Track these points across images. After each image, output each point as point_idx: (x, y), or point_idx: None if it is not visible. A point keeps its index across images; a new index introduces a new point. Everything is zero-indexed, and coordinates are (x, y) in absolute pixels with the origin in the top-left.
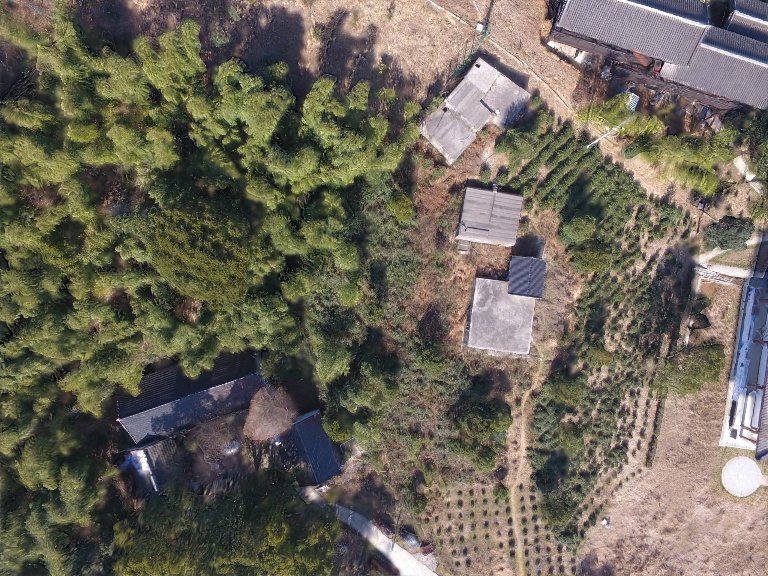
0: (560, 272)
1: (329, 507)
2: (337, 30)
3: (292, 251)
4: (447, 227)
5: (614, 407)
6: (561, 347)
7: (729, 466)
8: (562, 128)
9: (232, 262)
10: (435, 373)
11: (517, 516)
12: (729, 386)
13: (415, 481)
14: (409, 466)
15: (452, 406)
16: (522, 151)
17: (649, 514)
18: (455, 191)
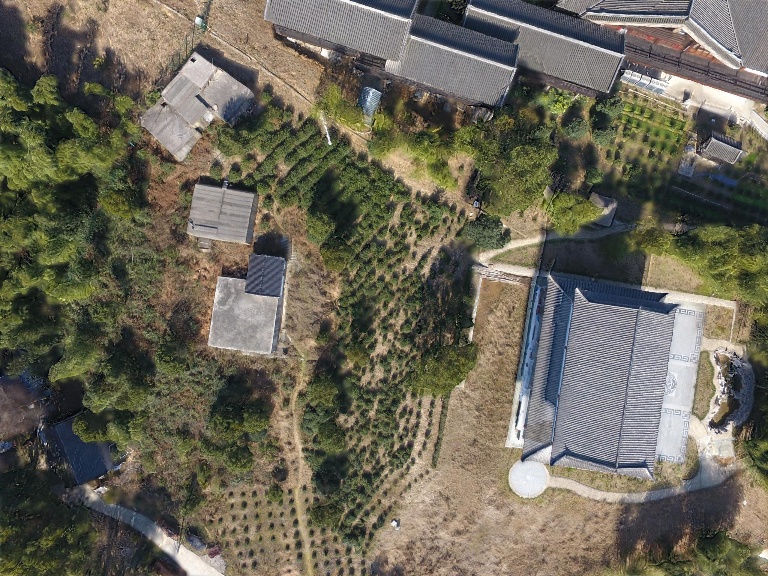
0: (313, 271)
1: (78, 509)
2: (57, 24)
3: (17, 249)
4: (181, 225)
5: (391, 407)
6: (322, 347)
7: (516, 467)
8: (302, 124)
9: None
10: (171, 373)
11: (303, 518)
12: (516, 386)
13: (193, 482)
14: (183, 467)
15: (214, 406)
16: (230, 147)
17: (439, 516)
18: (186, 188)
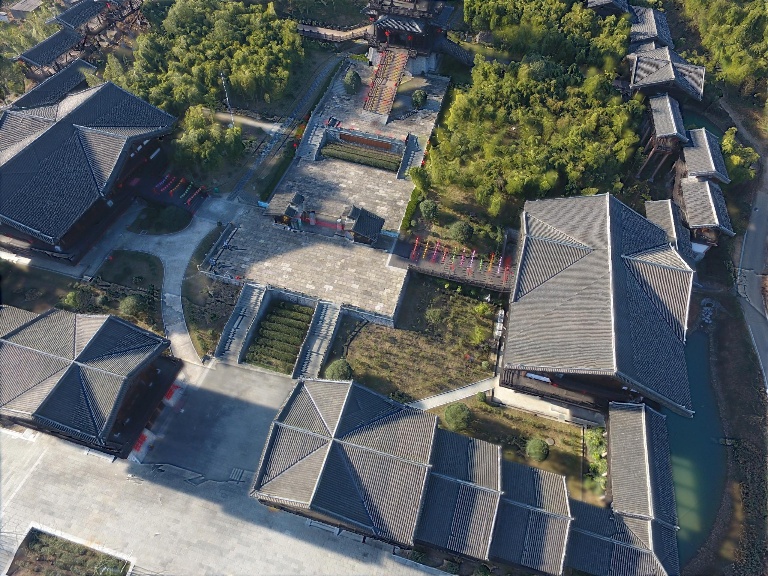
0: None
1: None
2: None
3: None
4: None
5: None
6: None
7: None
8: None
9: None
10: None
11: None
12: None
13: None
14: None
15: None
16: None
17: None
18: None
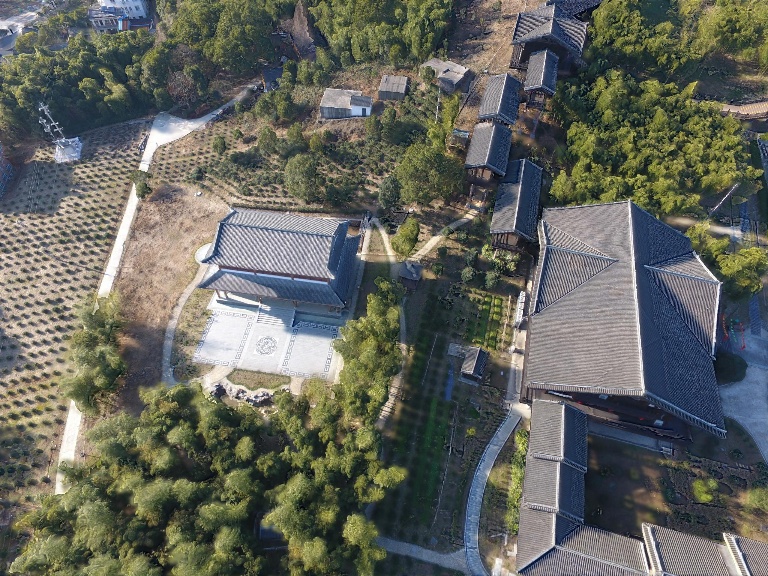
0: None
1: None
2: None
3: None
4: None
5: None
6: (321, 137)
7: None
8: None
9: (368, 6)
10: None
11: None
12: None
13: None
14: None
15: None
16: None
17: (197, 214)
18: None
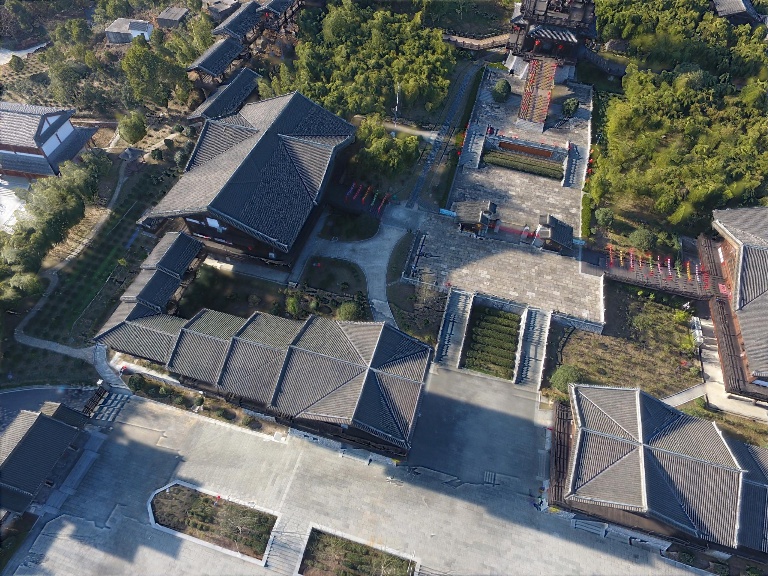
0: None
1: (71, 2)
2: None
3: None
4: None
5: None
6: None
7: None
8: None
9: None
10: None
11: None
12: None
13: None
14: None
15: None
16: None
17: None
18: None
